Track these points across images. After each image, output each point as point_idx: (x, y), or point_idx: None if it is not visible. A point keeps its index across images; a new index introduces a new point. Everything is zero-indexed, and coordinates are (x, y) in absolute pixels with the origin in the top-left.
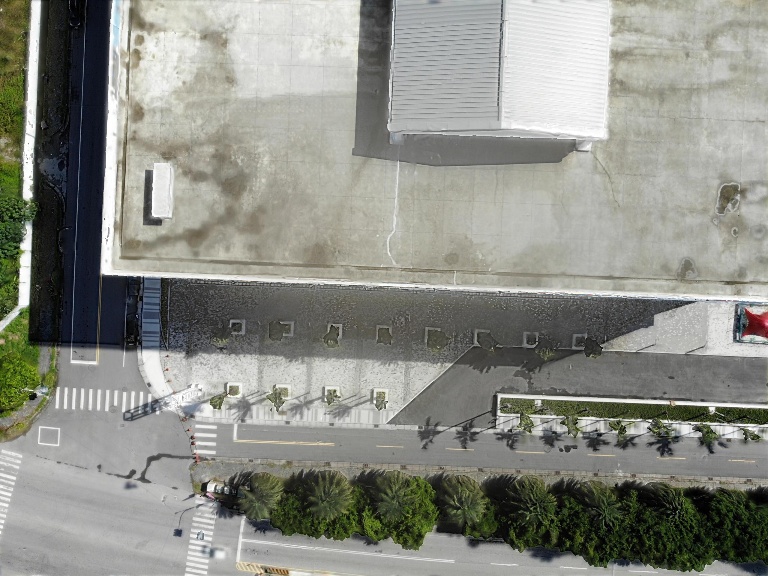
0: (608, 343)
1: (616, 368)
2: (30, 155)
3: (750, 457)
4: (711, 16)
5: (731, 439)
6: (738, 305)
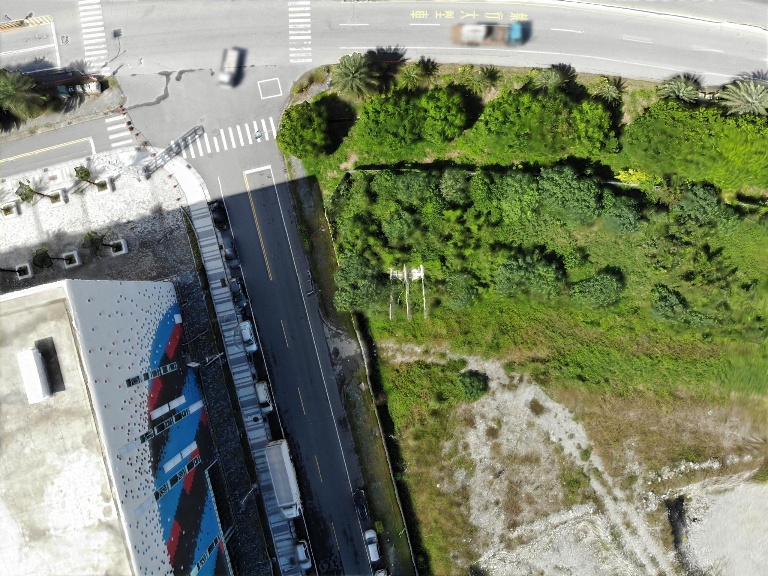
0: None
1: None
2: (369, 354)
3: None
4: None
5: None
6: None
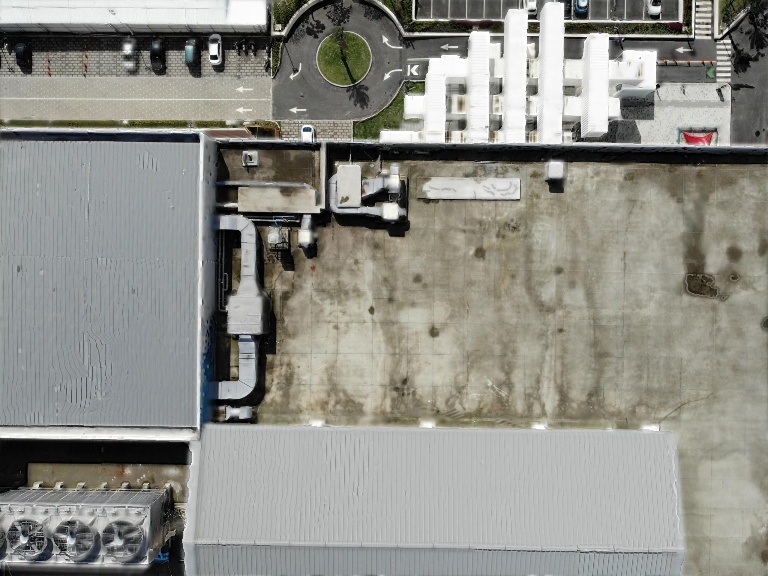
0: None
1: None
2: None
3: None
4: (522, 308)
5: None
6: None
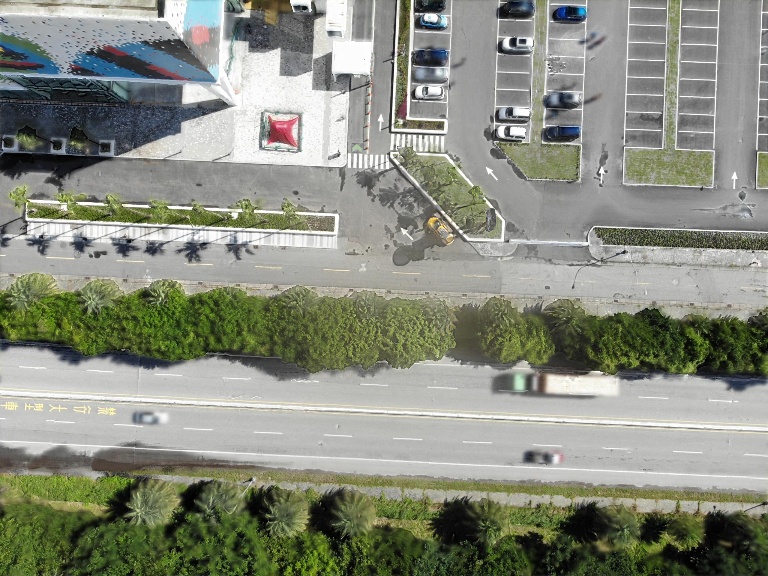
0: (136, 150)
1: (145, 175)
2: None
3: (277, 264)
4: None
5: (258, 246)
6: (264, 113)
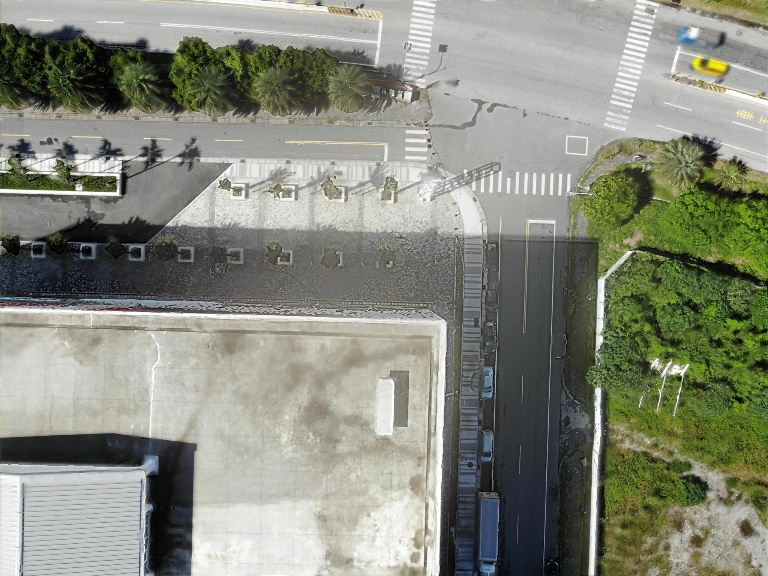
0: None
1: (4, 224)
2: None
3: None
4: None
5: None
6: None
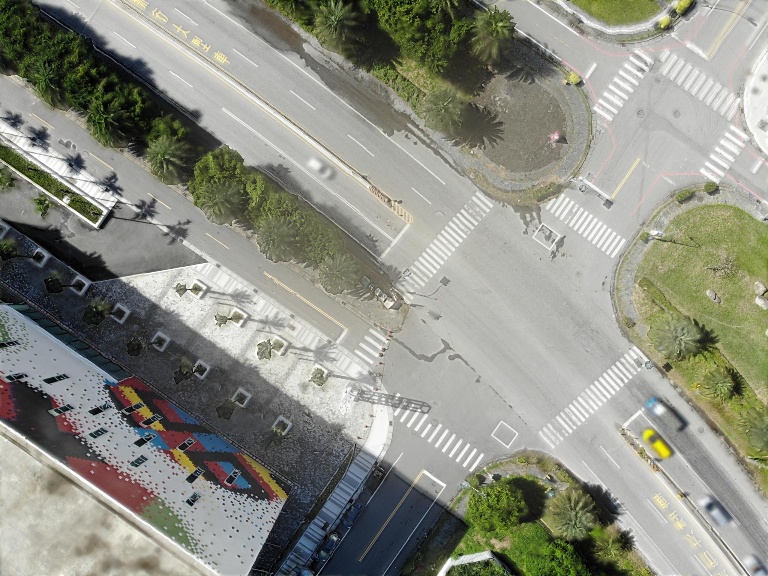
0: None
1: None
2: None
3: None
4: None
5: None
6: None
